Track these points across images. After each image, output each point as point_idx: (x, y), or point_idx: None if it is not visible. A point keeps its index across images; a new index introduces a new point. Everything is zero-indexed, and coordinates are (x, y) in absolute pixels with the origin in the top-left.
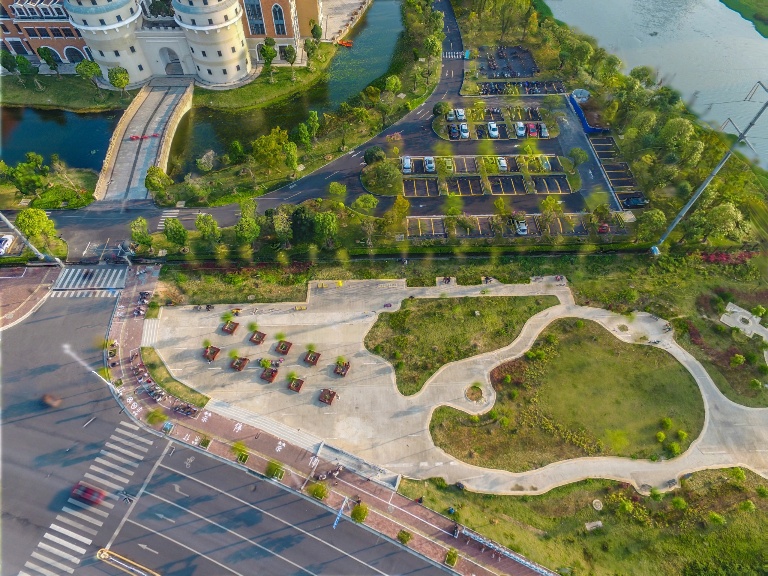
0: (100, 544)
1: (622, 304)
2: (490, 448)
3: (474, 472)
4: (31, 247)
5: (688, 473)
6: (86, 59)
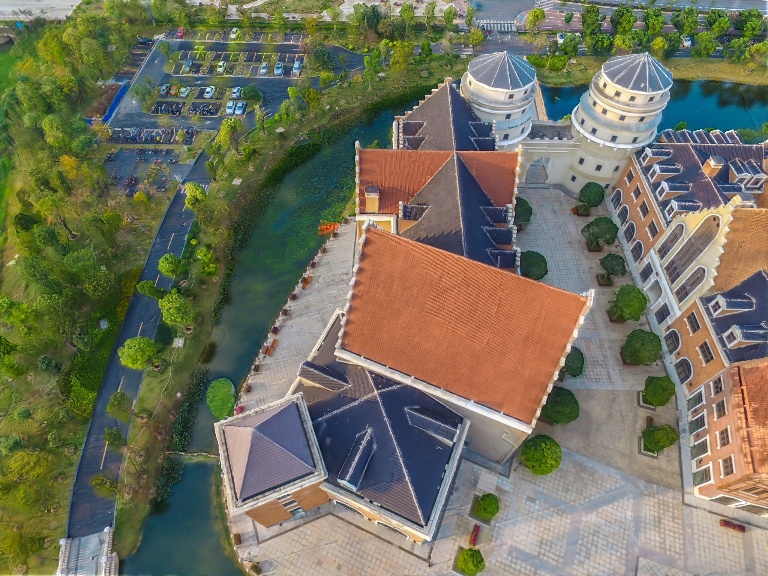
0: None
1: (204, 7)
2: None
3: None
4: None
5: None
6: None
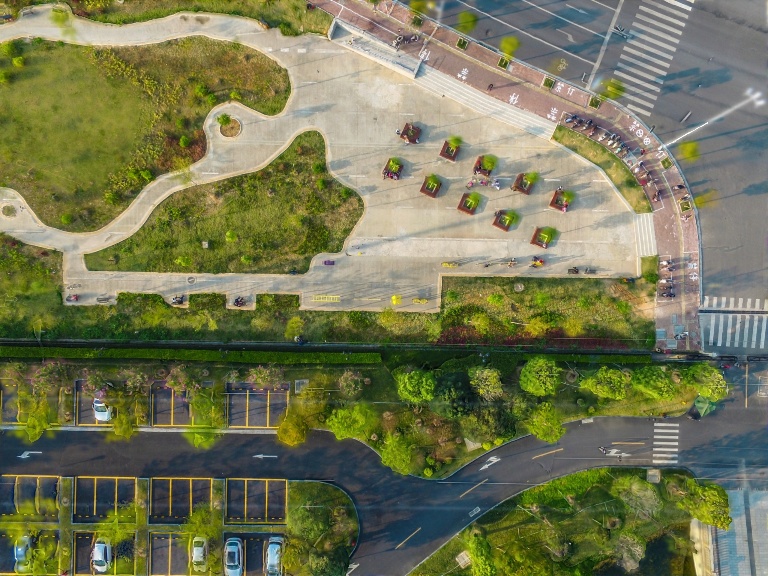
0: None
1: None
2: (224, 63)
3: (247, 39)
4: None
5: (5, 23)
6: None
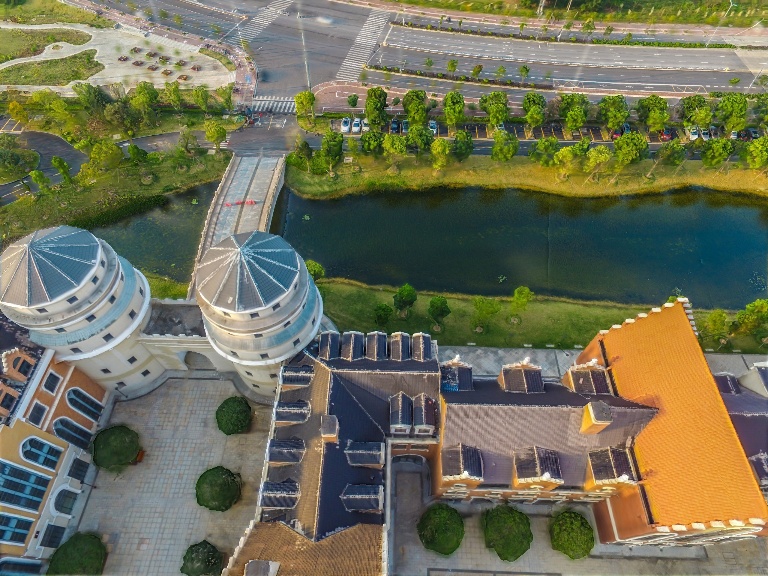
0: None
1: None
2: (66, 33)
3: (80, 29)
4: None
5: None
6: None
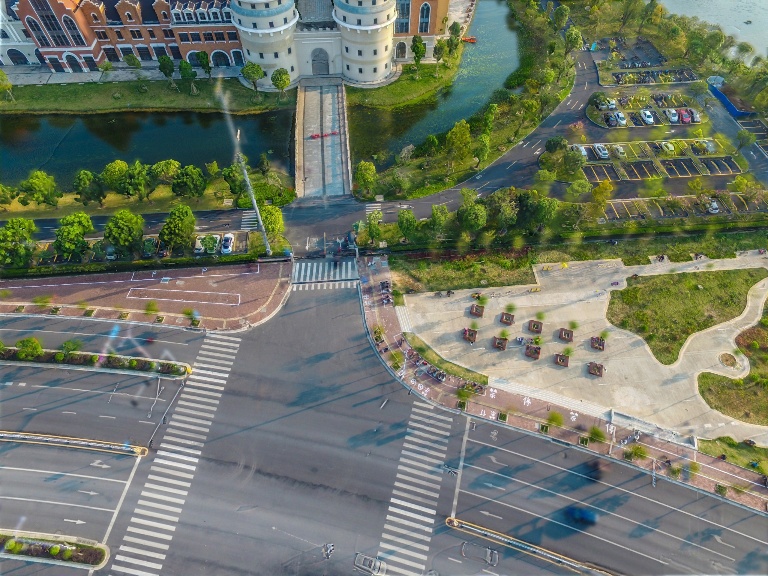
0: (445, 513)
1: None
2: (762, 408)
3: (756, 430)
4: (267, 243)
5: None
6: (249, 62)
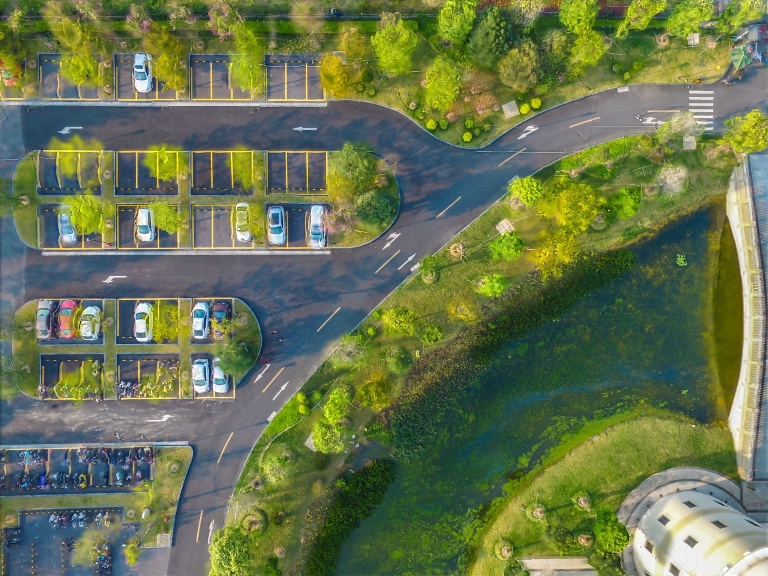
0: None
1: None
2: None
3: None
4: None
5: None
6: None
